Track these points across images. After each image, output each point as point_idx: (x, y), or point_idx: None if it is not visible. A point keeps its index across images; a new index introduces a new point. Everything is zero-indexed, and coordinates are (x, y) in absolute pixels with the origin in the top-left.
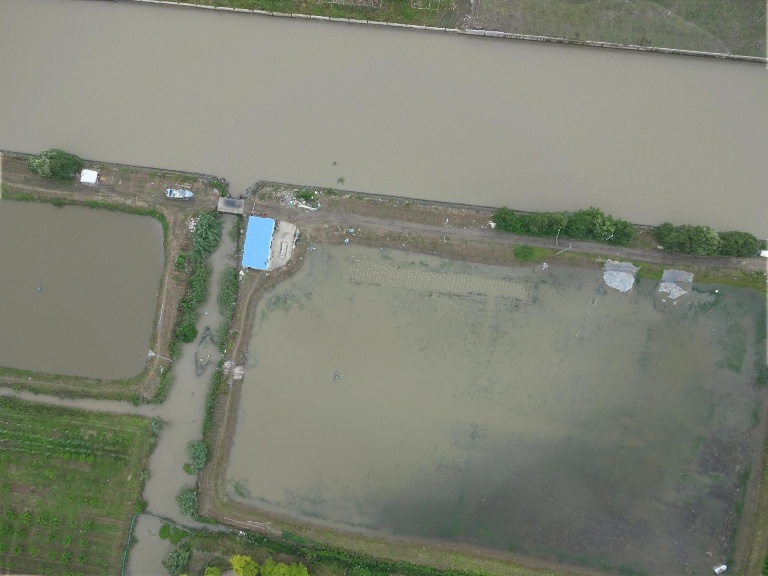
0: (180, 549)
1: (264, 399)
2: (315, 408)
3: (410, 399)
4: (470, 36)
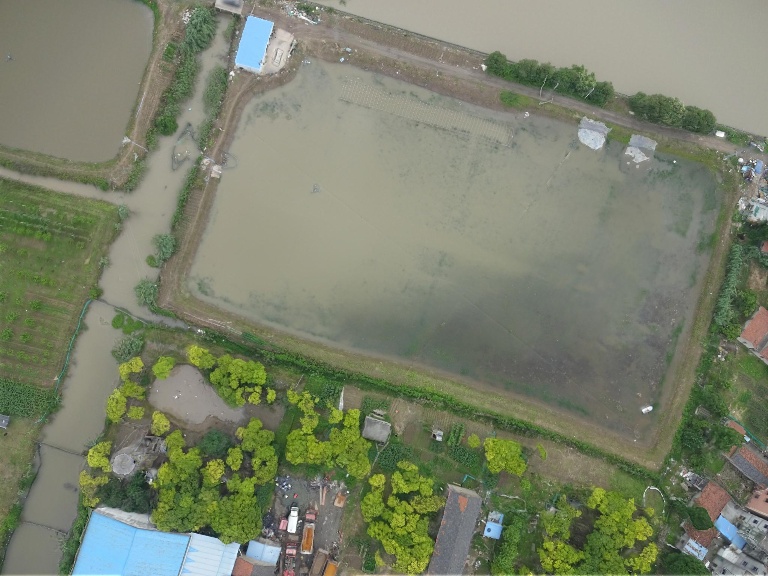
0: (134, 338)
1: (239, 202)
2: (290, 217)
3: (385, 221)
4: None
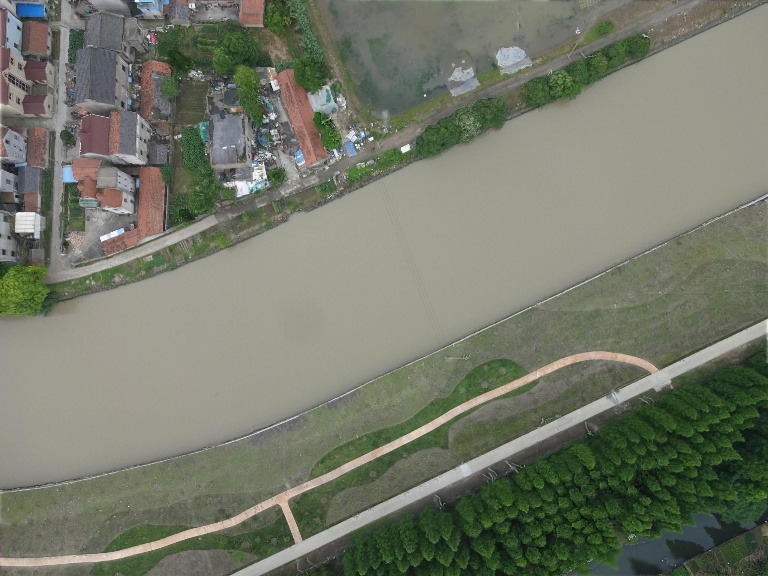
0: None
1: None
2: None
3: None
4: (766, 193)
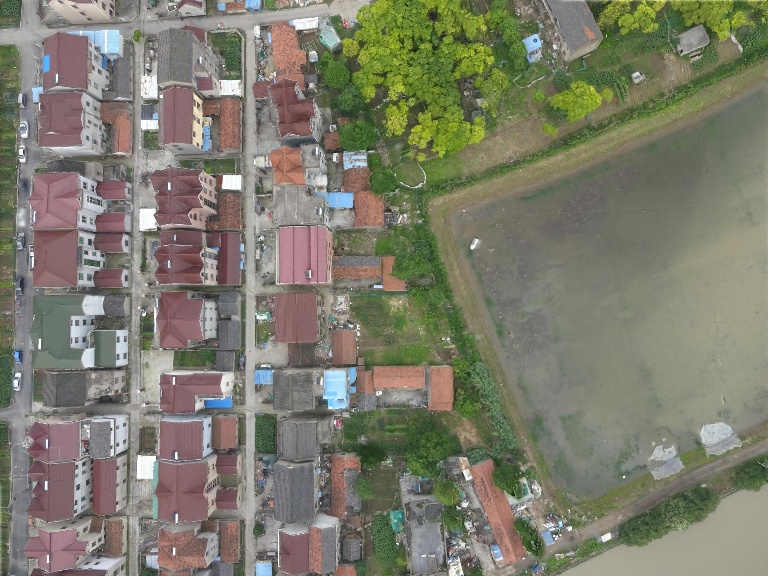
0: None
1: None
2: None
3: None
4: None
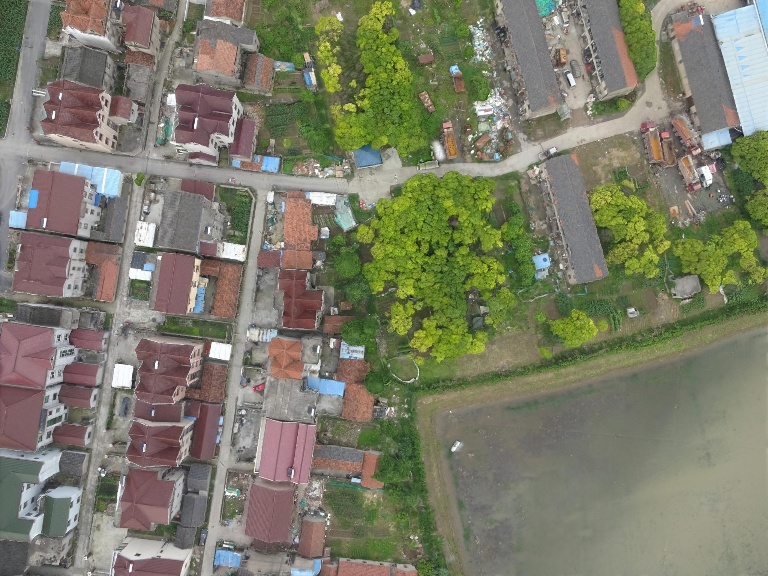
0: None
1: None
2: None
3: None
4: None
